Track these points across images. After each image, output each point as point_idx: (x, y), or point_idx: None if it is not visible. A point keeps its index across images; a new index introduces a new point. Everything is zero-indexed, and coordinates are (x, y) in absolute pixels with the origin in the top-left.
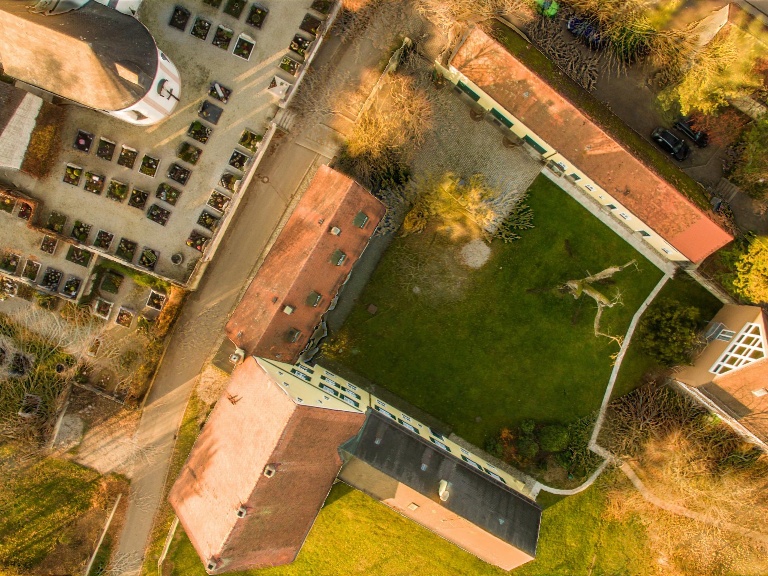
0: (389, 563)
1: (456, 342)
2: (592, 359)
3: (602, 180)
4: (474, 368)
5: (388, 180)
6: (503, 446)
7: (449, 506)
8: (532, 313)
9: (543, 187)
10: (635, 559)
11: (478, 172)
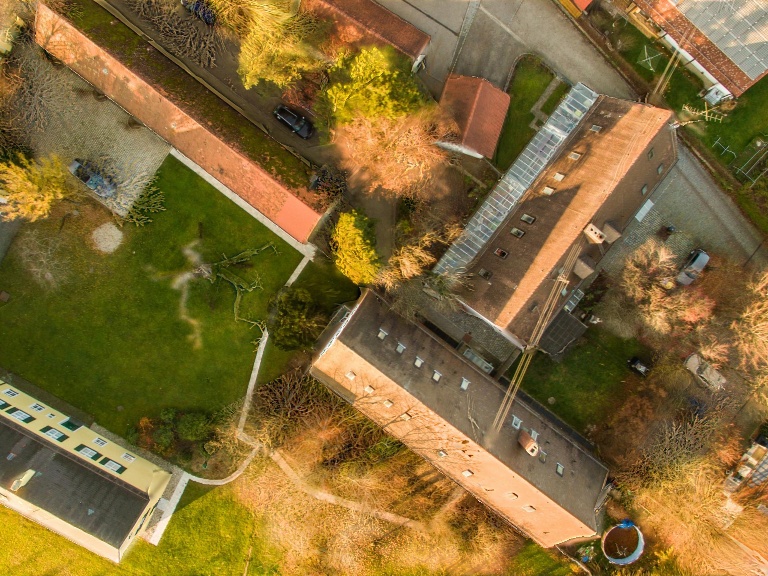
0: (43, 557)
1: (92, 329)
2: (234, 345)
3: (198, 159)
4: (112, 356)
5: (6, 163)
6: (139, 435)
7: (27, 496)
8: (169, 298)
9: (173, 168)
10: (292, 550)
11: (105, 154)
